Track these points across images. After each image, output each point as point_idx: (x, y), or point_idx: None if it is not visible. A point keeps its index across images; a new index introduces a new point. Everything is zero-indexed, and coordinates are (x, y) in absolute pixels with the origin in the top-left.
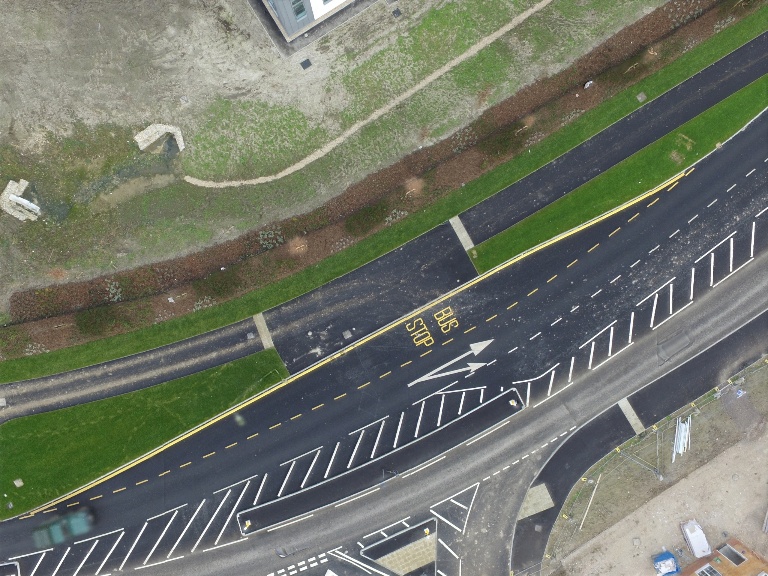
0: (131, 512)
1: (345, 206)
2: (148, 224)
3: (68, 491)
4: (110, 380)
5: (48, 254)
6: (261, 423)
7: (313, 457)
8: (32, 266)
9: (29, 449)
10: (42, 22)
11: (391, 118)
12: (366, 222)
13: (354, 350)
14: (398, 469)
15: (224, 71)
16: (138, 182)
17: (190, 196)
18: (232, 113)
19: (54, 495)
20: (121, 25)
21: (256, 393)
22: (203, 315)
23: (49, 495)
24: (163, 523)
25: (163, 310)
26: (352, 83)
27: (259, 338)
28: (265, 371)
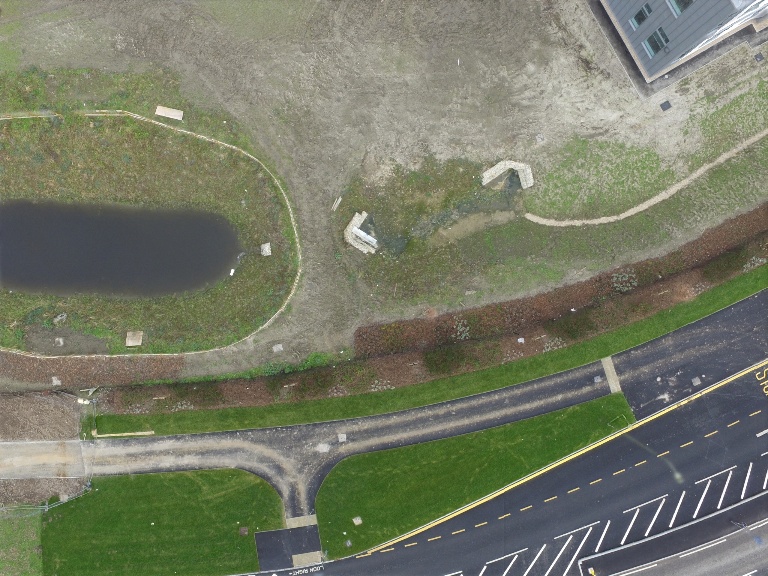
0: (470, 555)
1: (701, 251)
2: (498, 262)
3: (408, 531)
4: (453, 419)
5: (392, 289)
6: (605, 468)
7: (658, 505)
8: (378, 301)
9: (370, 487)
10: (403, 55)
11: (741, 162)
12: (727, 269)
13: (702, 397)
14: (746, 521)
15: (583, 110)
16: (478, 218)
17: (534, 234)
18: (588, 153)
19: (394, 535)
20: (481, 60)
21: (602, 438)
22: (551, 357)
23: (389, 534)
24: (502, 567)
25: (511, 350)
26: (708, 126)
27: (606, 382)
28: (612, 416)
